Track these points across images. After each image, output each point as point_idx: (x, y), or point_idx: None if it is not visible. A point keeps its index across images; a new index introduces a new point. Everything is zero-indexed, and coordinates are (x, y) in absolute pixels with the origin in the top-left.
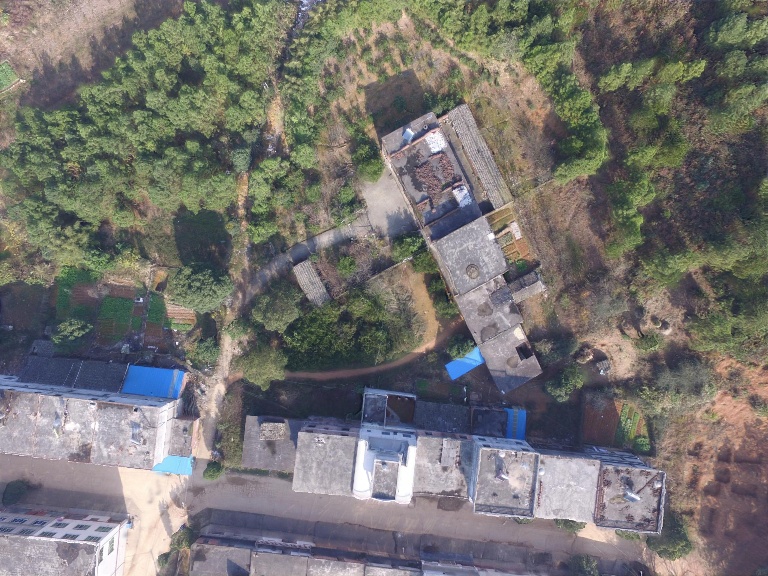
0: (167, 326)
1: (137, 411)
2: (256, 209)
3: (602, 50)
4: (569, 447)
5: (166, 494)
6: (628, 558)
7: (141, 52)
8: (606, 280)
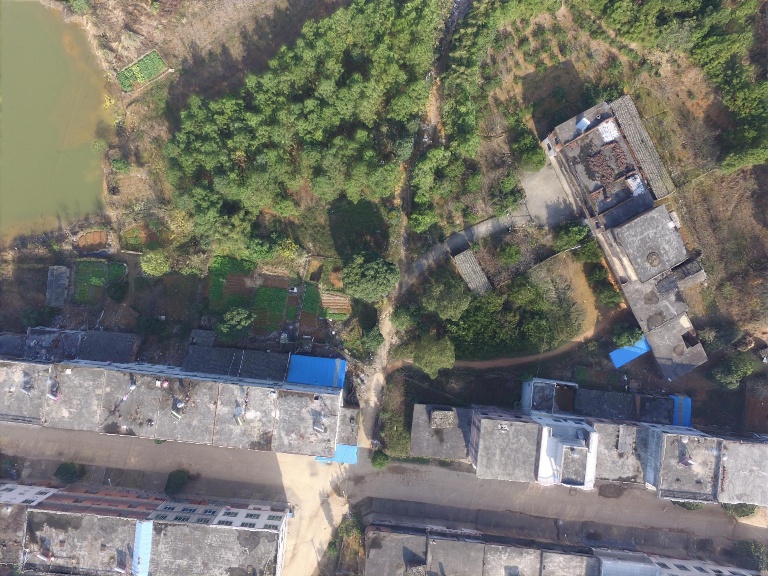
0: (322, 316)
1: (318, 399)
2: (419, 198)
3: None
4: (736, 433)
5: (326, 483)
6: None
7: (310, 41)
8: None
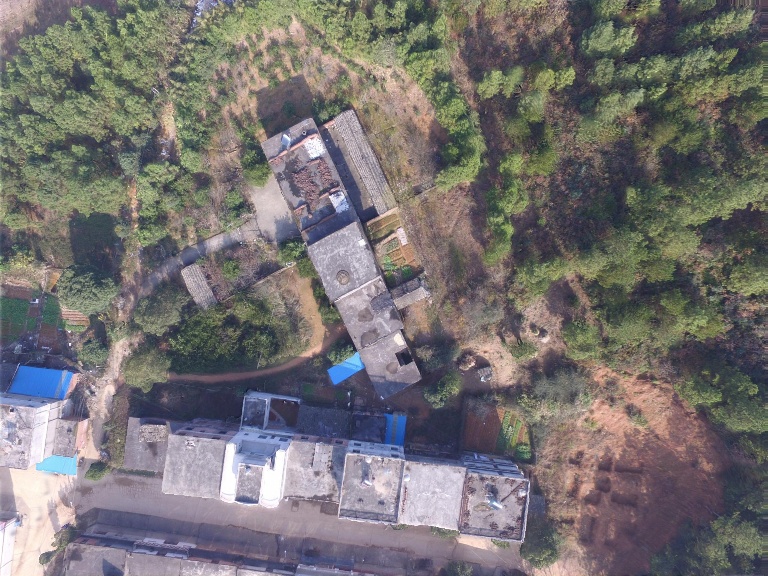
0: (61, 327)
1: (13, 411)
2: (144, 213)
3: (484, 57)
4: (446, 454)
5: (55, 493)
6: (508, 566)
7: (29, 57)
8: (481, 287)
